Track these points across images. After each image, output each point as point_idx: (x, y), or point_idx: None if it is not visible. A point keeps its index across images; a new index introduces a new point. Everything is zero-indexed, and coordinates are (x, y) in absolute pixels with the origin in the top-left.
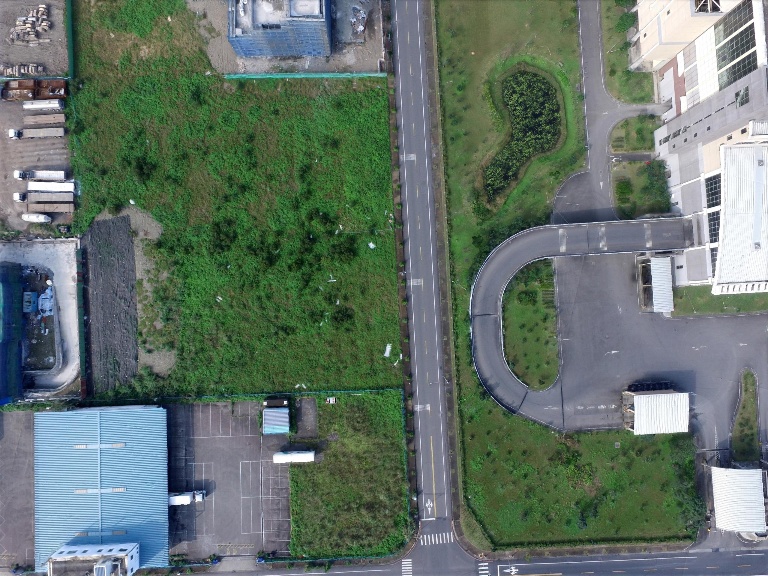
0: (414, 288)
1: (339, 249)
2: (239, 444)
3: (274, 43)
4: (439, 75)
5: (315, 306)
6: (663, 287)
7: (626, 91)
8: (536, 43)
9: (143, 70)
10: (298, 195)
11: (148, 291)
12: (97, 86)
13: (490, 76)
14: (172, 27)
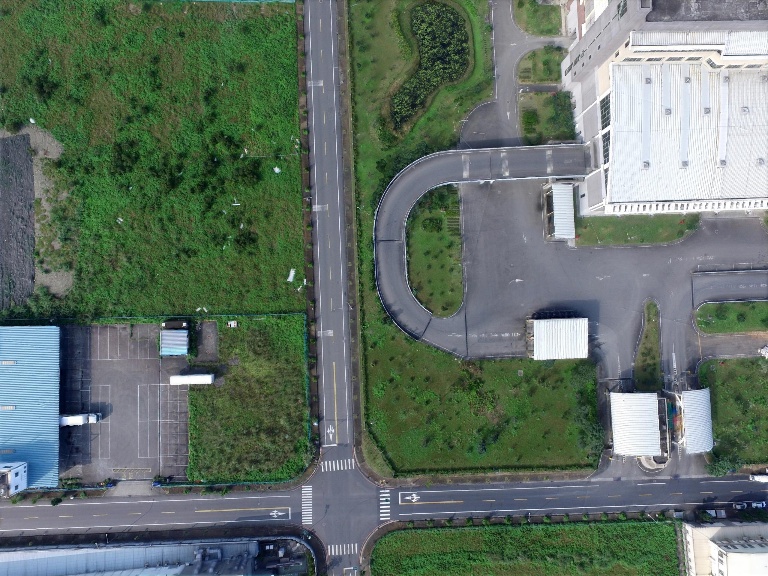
0: (319, 214)
1: (242, 171)
2: (137, 367)
3: None
4: (348, 2)
5: (218, 229)
6: (564, 214)
7: (534, 23)
8: None
9: None
10: (203, 118)
11: (46, 211)
12: None
13: (399, 5)
14: None
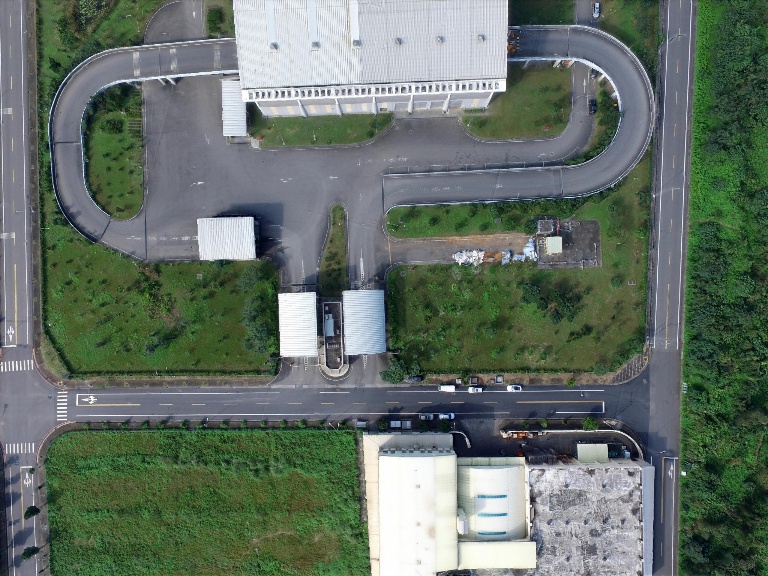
0: (4, 117)
1: None
2: None
3: None
4: None
5: None
6: (234, 111)
7: None
8: None
9: None
10: None
11: None
12: None
13: None
14: None
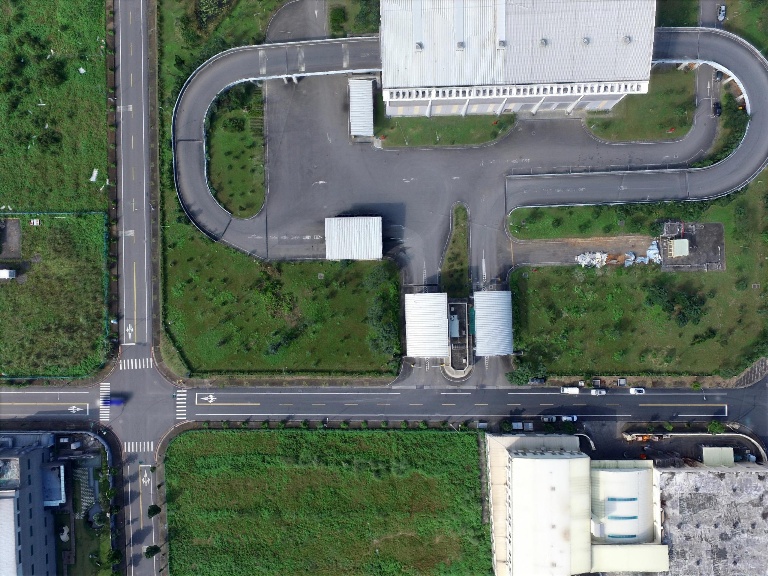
0: (124, 114)
1: (44, 70)
2: None
3: None
4: None
5: (23, 129)
6: (362, 110)
7: None
8: None
9: None
10: (10, 19)
11: None
12: None
13: None
14: None
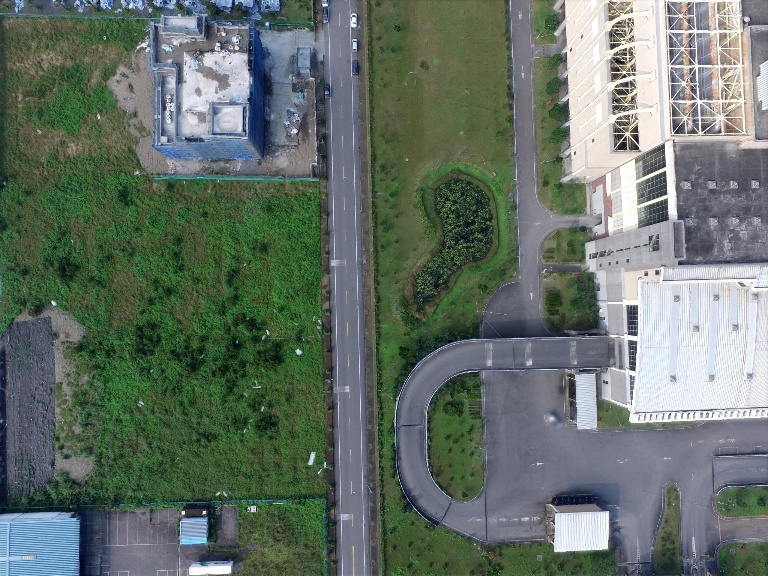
0: (340, 395)
1: (264, 357)
2: (156, 552)
3: (201, 150)
4: (372, 181)
5: (239, 413)
6: (587, 404)
7: (559, 202)
8: (470, 151)
9: (70, 168)
10: (225, 299)
11: (67, 395)
12: (22, 184)
13: (423, 183)
14: (101, 125)
